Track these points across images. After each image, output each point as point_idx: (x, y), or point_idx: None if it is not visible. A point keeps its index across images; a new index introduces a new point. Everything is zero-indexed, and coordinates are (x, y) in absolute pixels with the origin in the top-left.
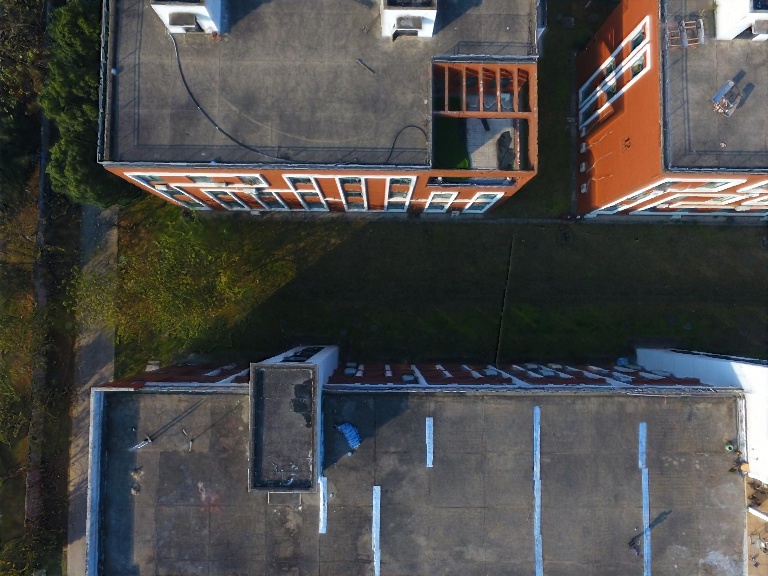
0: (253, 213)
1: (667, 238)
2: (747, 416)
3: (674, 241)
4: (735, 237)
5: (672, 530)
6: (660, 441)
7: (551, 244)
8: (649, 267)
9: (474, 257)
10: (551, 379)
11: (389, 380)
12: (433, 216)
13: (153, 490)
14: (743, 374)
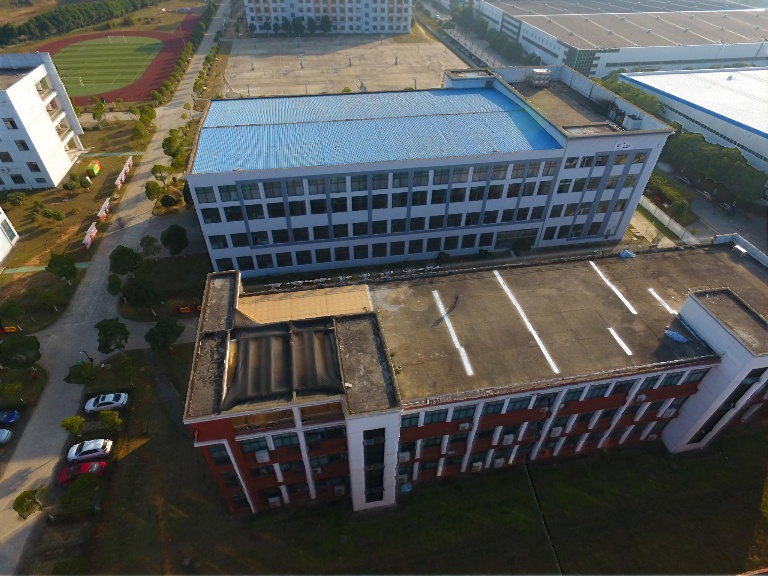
0: None
1: None
2: None
3: None
4: None
5: (427, 318)
6: (453, 366)
7: None
8: None
9: (603, 571)
10: (523, 418)
11: (655, 393)
12: None
13: (766, 294)
14: None
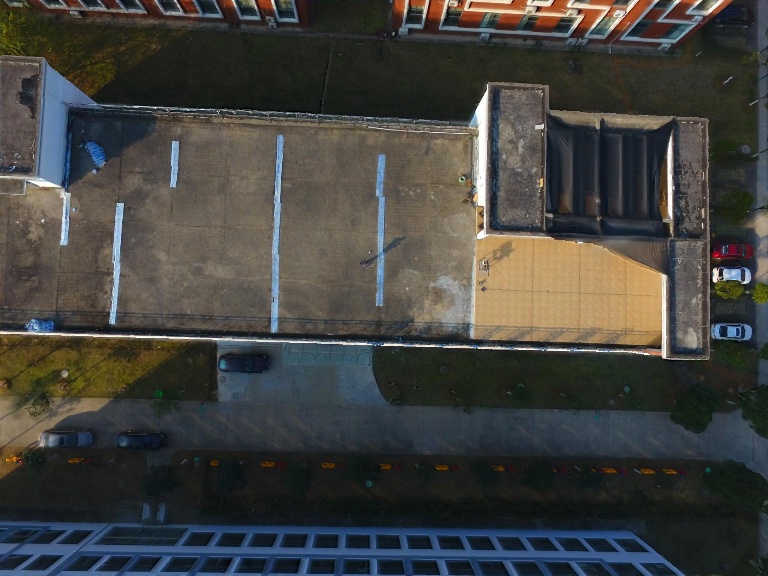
0: (73, 13)
1: (479, 58)
2: (479, 149)
3: (485, 61)
4: (544, 60)
5: (405, 255)
6: (398, 172)
7: (367, 59)
8: (460, 84)
9: (292, 68)
10: None
11: None
12: (253, 27)
13: None
14: (479, 112)
